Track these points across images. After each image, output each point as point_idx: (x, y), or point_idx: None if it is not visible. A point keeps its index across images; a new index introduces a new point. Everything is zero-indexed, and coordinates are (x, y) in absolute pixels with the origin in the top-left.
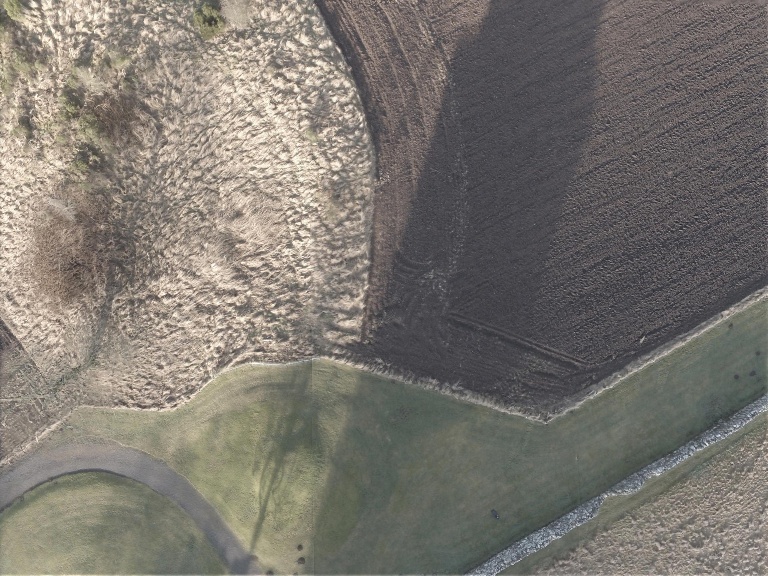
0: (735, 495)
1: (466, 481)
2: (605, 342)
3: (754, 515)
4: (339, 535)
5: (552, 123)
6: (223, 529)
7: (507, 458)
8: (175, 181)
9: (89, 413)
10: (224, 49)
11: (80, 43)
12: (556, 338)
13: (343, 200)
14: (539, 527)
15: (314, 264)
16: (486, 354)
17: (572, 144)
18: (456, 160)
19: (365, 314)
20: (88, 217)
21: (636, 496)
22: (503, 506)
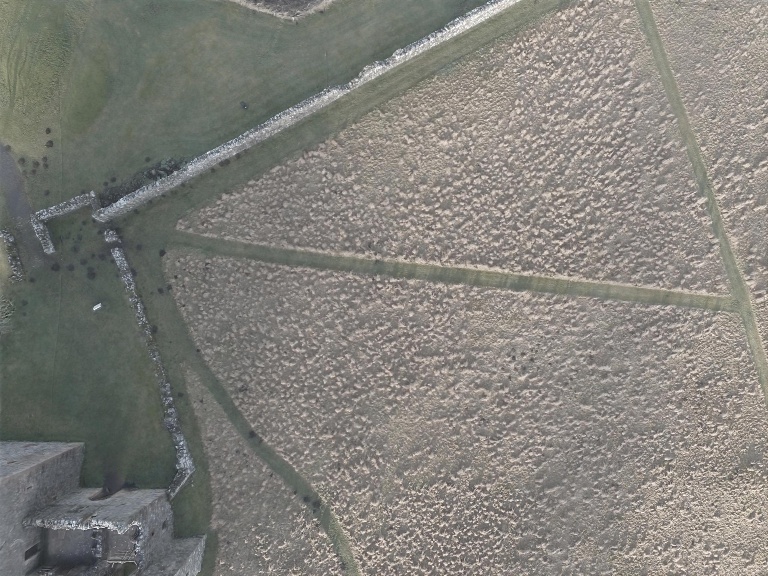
0: (483, 91)
1: (216, 75)
2: None
3: (504, 114)
4: (85, 117)
5: None
6: None
7: (257, 54)
8: None
9: None
10: None
11: None
12: None
13: None
14: None
15: None
16: None
17: None
18: None
19: None
20: None
21: (385, 91)
22: (252, 98)
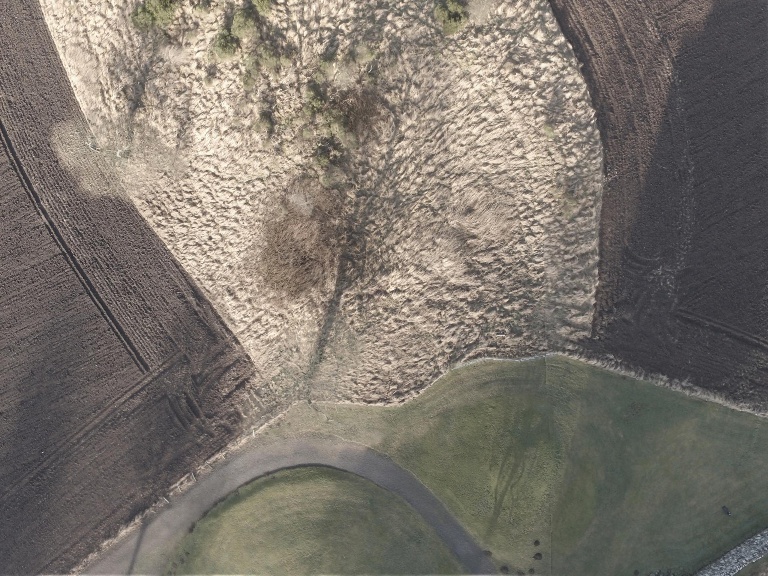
0: None
1: (697, 478)
2: None
3: None
4: (577, 531)
5: None
6: (453, 524)
7: (736, 455)
8: (408, 176)
9: (308, 408)
10: (463, 45)
11: (324, 38)
12: None
13: (577, 196)
14: None
15: (548, 260)
16: (715, 351)
17: None
18: (682, 157)
19: (595, 310)
20: (322, 212)
21: None
22: (734, 503)
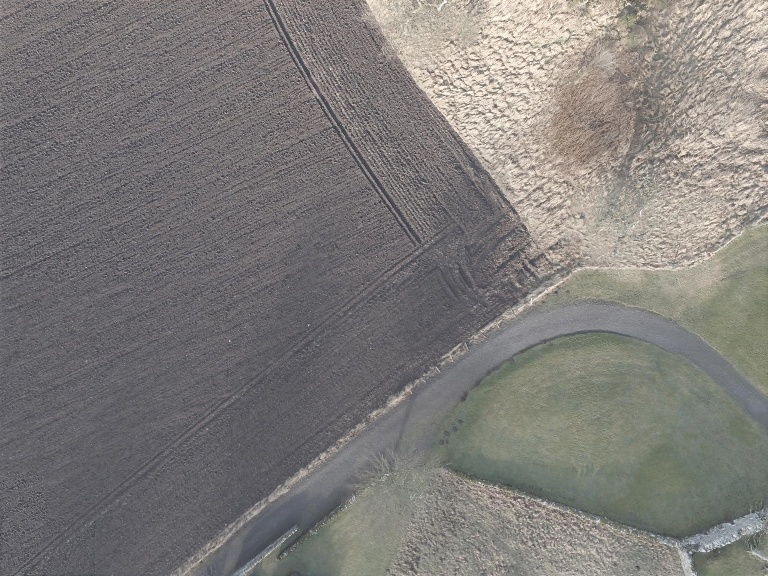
0: None
1: None
2: None
3: None
4: None
5: None
6: (743, 384)
7: None
8: (704, 41)
9: (589, 275)
10: None
11: None
12: None
13: None
14: None
15: None
16: None
17: None
18: None
19: None
20: (621, 74)
21: None
22: None
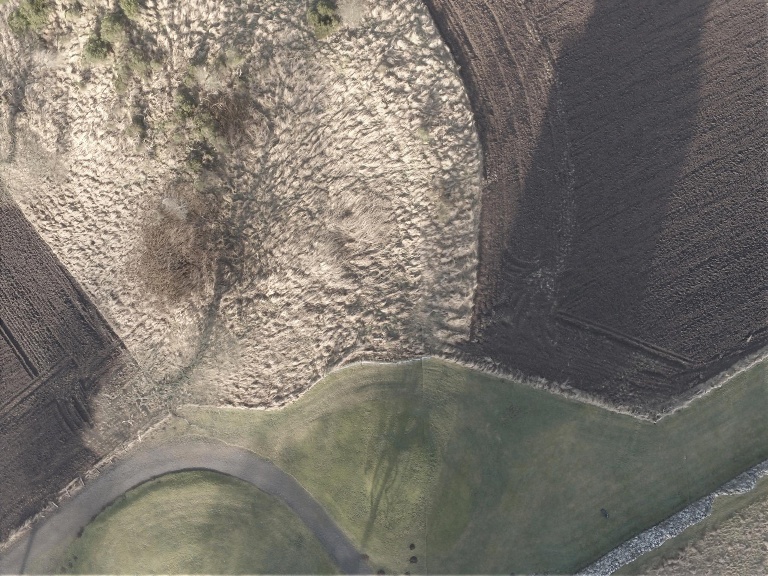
0: None
1: (575, 480)
2: (712, 341)
3: None
4: (452, 534)
5: (658, 122)
6: (332, 528)
7: (616, 457)
8: (285, 180)
9: (193, 412)
10: (337, 48)
11: (195, 42)
12: (664, 337)
13: (453, 199)
14: (649, 526)
15: (424, 263)
16: (594, 353)
17: (678, 143)
18: (563, 159)
19: (473, 313)
20: (198, 216)
21: (744, 495)
22: (612, 505)
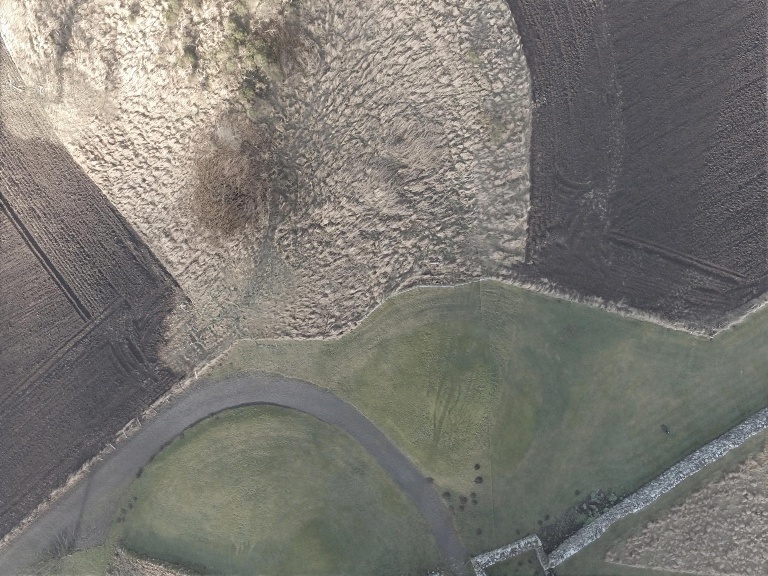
0: None
1: (635, 397)
2: (764, 256)
3: None
4: (516, 453)
5: (702, 42)
6: (394, 454)
7: (674, 374)
8: (336, 108)
9: (249, 347)
10: None
11: None
12: (716, 253)
13: (505, 121)
14: (709, 440)
15: (478, 186)
16: (648, 271)
17: (723, 62)
18: (610, 81)
19: (528, 235)
20: (252, 146)
21: None
22: (672, 421)
